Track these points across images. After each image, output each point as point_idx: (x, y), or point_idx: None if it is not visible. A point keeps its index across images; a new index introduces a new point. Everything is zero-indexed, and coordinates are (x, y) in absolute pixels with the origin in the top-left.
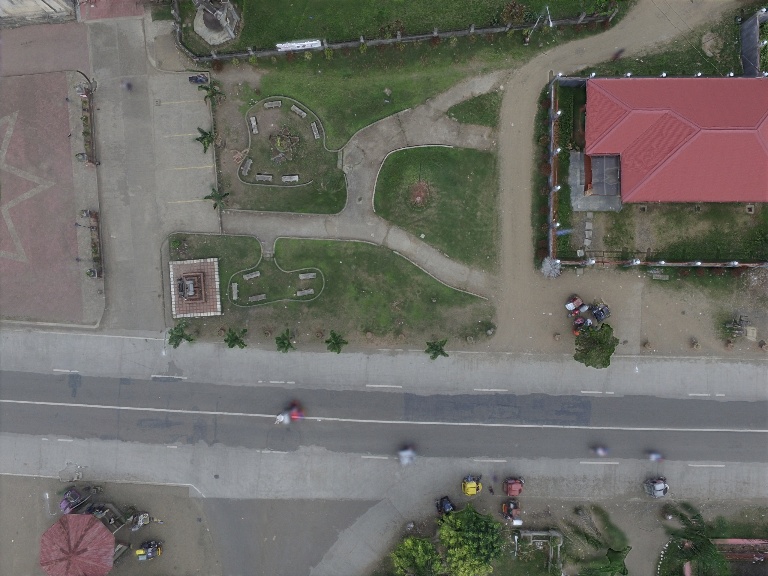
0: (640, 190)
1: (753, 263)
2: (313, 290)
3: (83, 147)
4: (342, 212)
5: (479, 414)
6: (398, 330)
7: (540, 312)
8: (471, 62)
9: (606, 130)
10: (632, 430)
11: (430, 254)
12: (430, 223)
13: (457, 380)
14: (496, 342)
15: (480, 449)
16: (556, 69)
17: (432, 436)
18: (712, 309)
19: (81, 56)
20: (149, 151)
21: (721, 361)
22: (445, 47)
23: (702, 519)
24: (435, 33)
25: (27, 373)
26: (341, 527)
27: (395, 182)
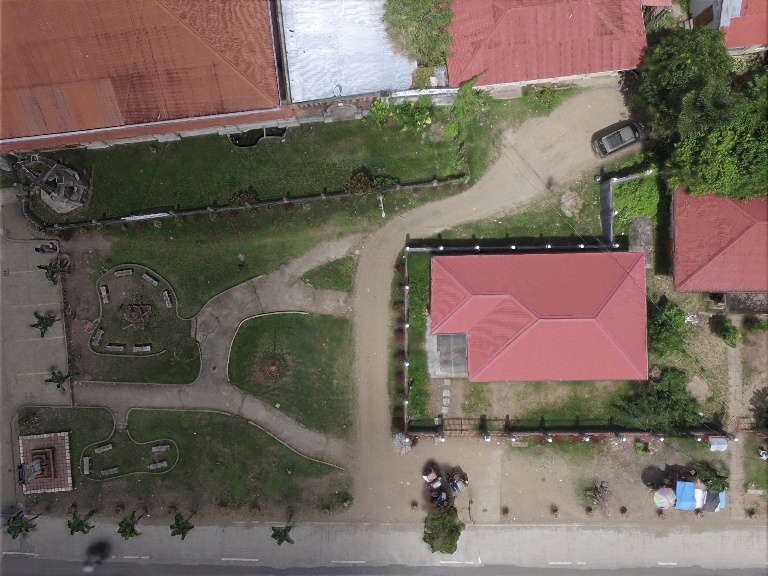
0: (485, 372)
1: (610, 432)
2: (166, 463)
3: None
4: (196, 382)
5: None
6: (253, 502)
7: (398, 481)
8: (326, 226)
9: (449, 312)
10: None
11: (286, 423)
12: (285, 392)
13: (314, 552)
14: (354, 513)
15: None
16: (413, 232)
17: None
18: (573, 475)
19: None
20: None
21: (582, 528)
22: (299, 211)
23: None
24: (285, 201)
25: None
26: None
27: (249, 351)
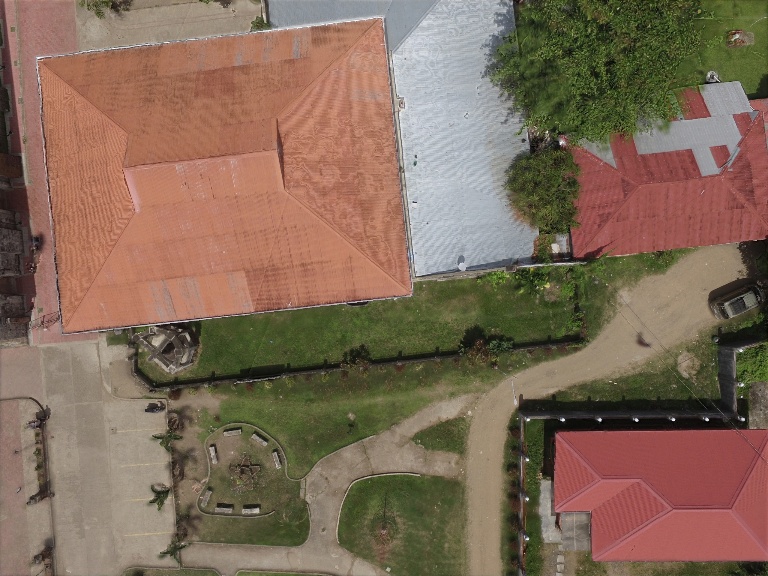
0: (611, 553)
1: None
2: None
3: (37, 479)
4: (305, 543)
5: None
6: None
7: None
8: (438, 385)
9: (575, 492)
10: None
11: None
12: (396, 555)
13: None
14: None
15: None
16: (526, 392)
17: None
18: None
19: (34, 381)
20: (105, 481)
21: None
22: (411, 370)
23: None
24: None
25: None
26: None
27: (360, 513)
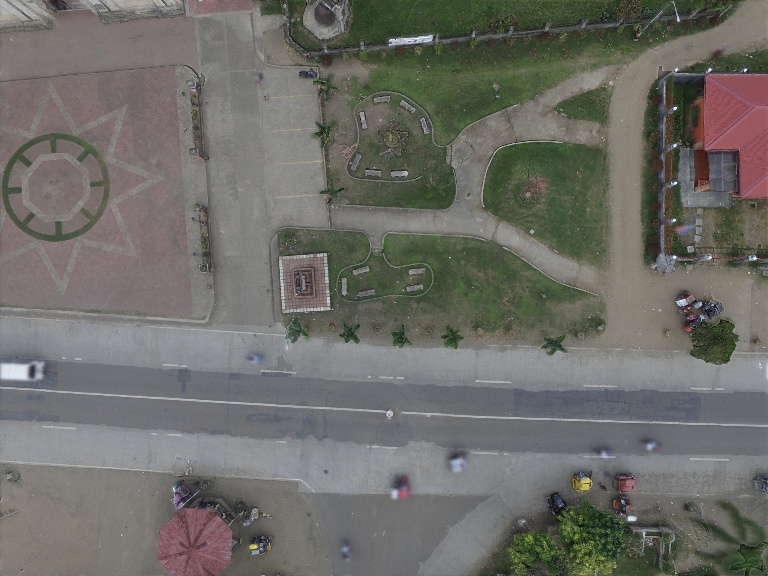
0: (760, 186)
1: None
2: (422, 285)
3: (192, 142)
4: (451, 207)
5: (589, 410)
6: (508, 326)
7: (650, 308)
8: (580, 57)
9: (727, 126)
10: (742, 427)
11: (539, 250)
12: (539, 219)
13: (566, 376)
14: (605, 338)
15: (590, 445)
16: (665, 65)
17: (542, 432)
18: None
19: (189, 50)
20: (258, 146)
21: None
22: (554, 42)
23: None
24: (547, 28)
25: (136, 368)
26: (451, 523)
27: (504, 178)
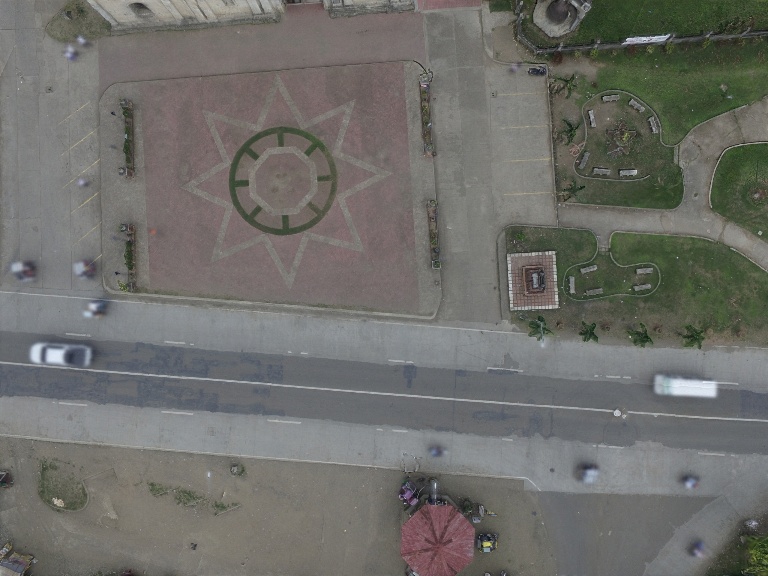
0: None
1: None
2: (650, 285)
3: (420, 137)
4: (678, 207)
5: None
6: (735, 327)
7: None
8: None
9: None
10: None
11: (767, 251)
12: (767, 220)
13: None
14: None
15: None
16: None
17: None
18: None
19: (417, 46)
20: (485, 143)
21: None
22: None
23: None
24: None
25: (362, 363)
26: (677, 523)
27: (732, 178)
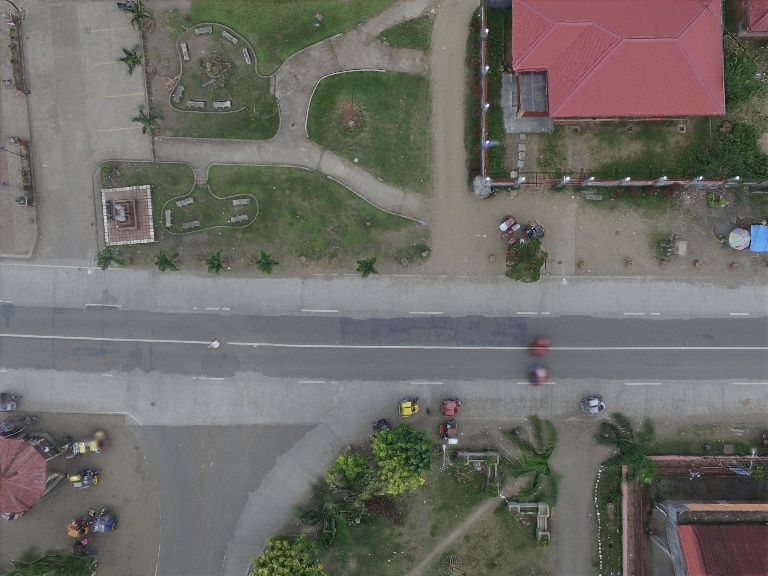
0: (567, 104)
1: (684, 180)
2: (247, 216)
3: (12, 76)
4: (275, 138)
5: (415, 337)
6: (333, 254)
7: (475, 234)
8: None
9: (532, 44)
10: (568, 350)
11: (364, 178)
12: (363, 147)
13: (393, 303)
14: (431, 265)
15: (417, 372)
16: None
17: (368, 360)
18: (646, 228)
19: None
20: (80, 79)
21: (655, 280)
22: None
23: (630, 427)
24: None
25: None
26: (279, 452)
27: (328, 107)
